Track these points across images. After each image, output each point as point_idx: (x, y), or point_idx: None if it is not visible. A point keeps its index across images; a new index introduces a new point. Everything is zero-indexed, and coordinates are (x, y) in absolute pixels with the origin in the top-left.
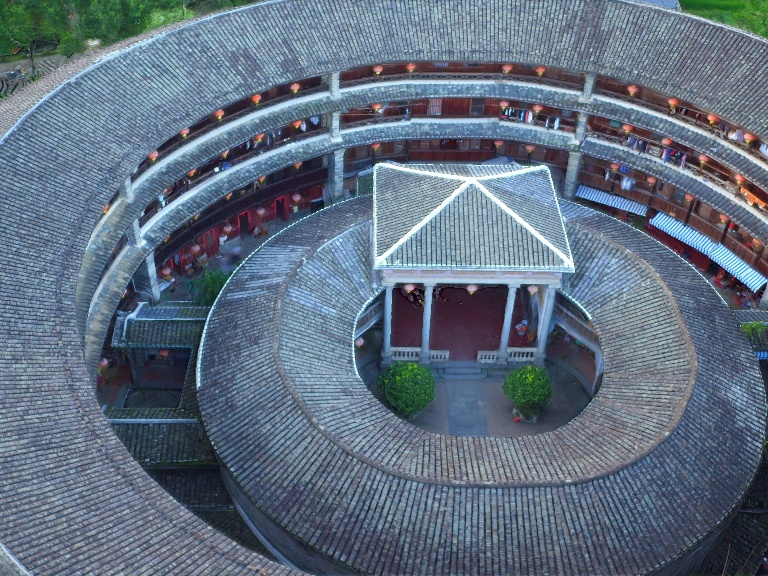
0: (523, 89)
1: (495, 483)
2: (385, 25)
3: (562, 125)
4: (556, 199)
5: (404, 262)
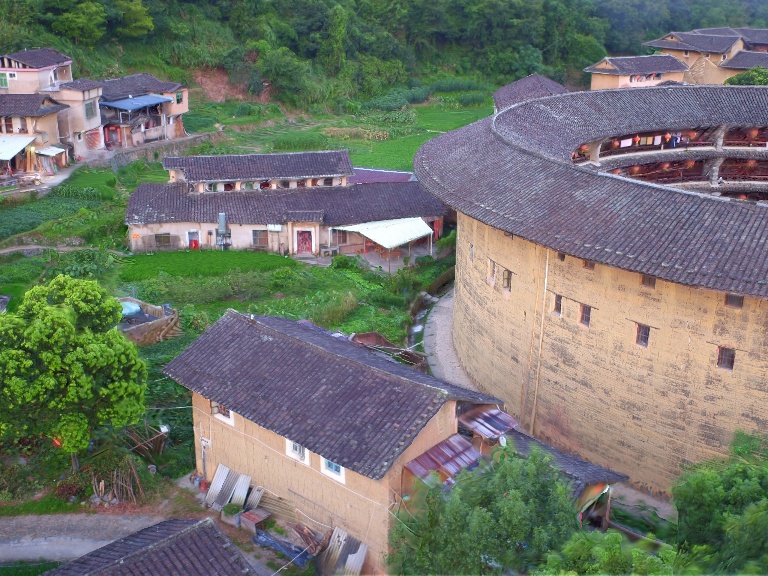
0: None
1: None
2: None
3: None
4: None
5: None
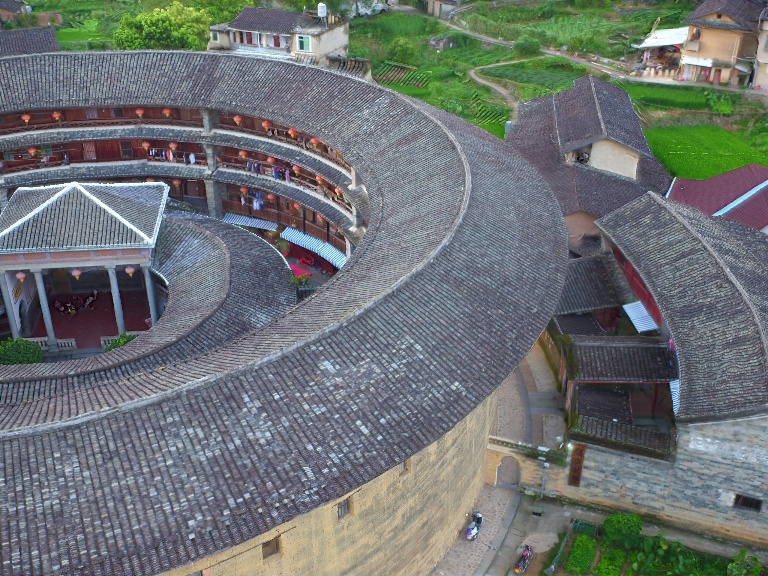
0: (158, 130)
1: (7, 379)
2: (32, 83)
3: (198, 160)
4: (162, 203)
5: (4, 248)
